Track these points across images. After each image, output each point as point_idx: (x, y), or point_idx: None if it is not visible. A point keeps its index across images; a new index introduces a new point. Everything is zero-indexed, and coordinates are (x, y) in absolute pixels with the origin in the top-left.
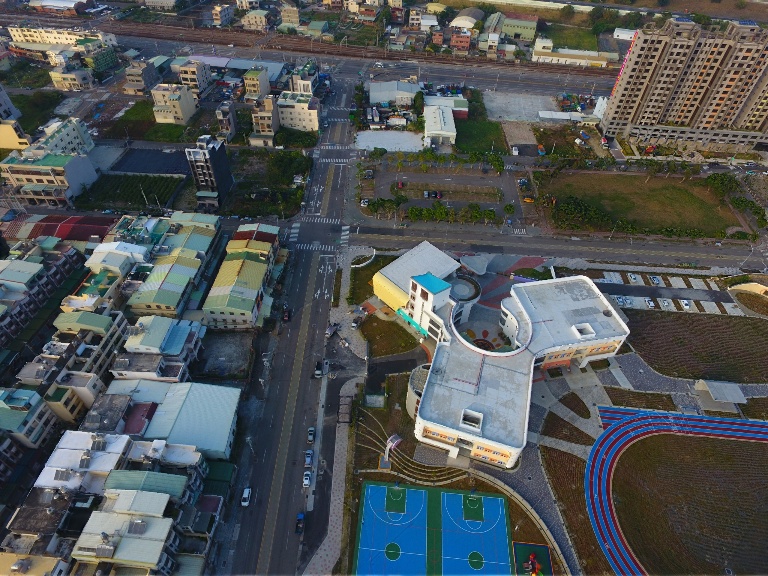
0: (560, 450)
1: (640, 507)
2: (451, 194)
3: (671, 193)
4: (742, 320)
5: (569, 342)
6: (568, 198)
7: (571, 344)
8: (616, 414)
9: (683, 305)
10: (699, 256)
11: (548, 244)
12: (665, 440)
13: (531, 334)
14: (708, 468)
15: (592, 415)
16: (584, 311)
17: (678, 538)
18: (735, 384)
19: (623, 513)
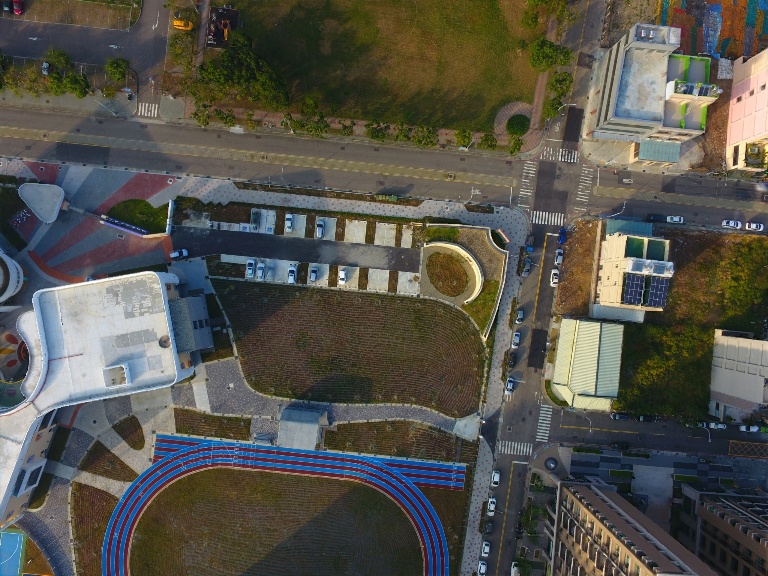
0: (94, 487)
1: (159, 543)
2: (43, 1)
3: (459, 3)
4: (409, 304)
5: (93, 392)
6: (231, 41)
7: (87, 401)
8: (174, 444)
9: (338, 279)
10: (419, 174)
11: (186, 143)
12: (217, 475)
13: (37, 385)
14: (250, 504)
15: (145, 446)
16: (133, 338)
17: (184, 570)
18: (315, 424)
19: (138, 551)
